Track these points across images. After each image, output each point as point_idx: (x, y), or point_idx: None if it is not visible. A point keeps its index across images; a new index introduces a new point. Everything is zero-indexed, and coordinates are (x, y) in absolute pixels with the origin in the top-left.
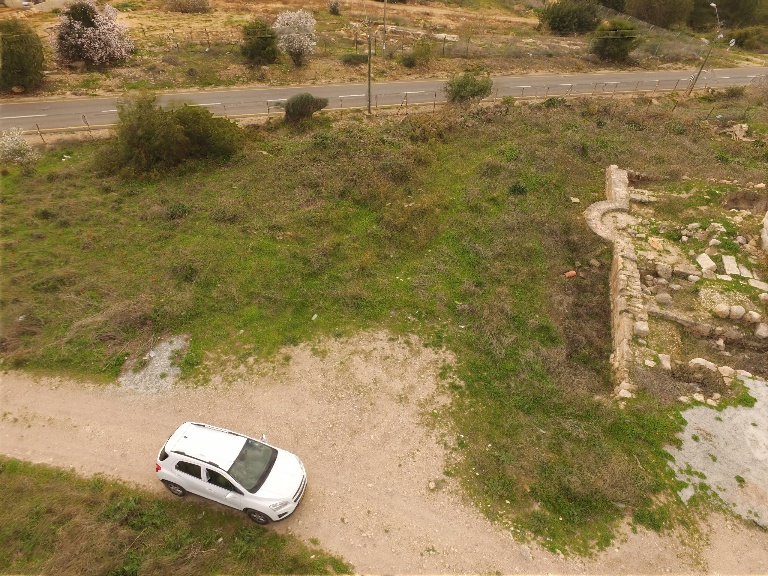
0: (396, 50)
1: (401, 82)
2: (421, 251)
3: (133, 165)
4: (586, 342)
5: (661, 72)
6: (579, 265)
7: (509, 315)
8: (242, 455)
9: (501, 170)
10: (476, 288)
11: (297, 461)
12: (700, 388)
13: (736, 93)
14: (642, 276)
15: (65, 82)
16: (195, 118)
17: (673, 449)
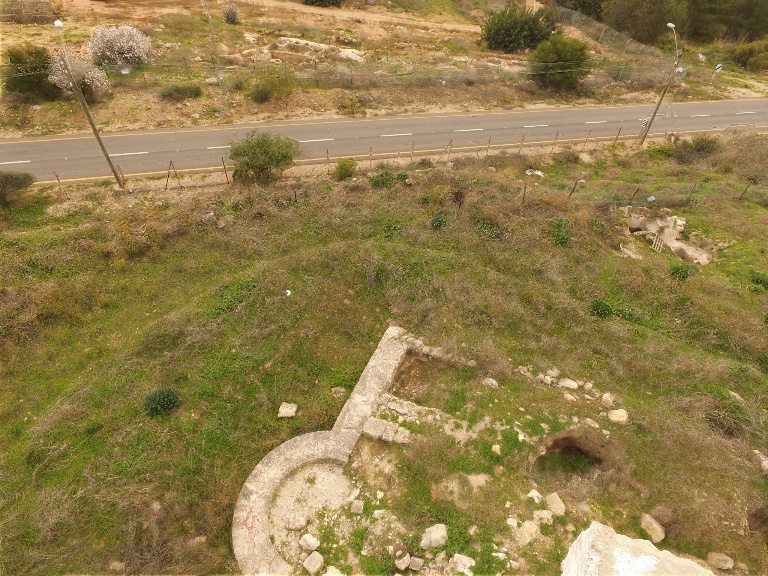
0: (248, 79)
1: (224, 128)
2: None
3: None
4: None
5: (617, 107)
6: None
7: None
8: None
9: (183, 338)
10: None
11: None
12: None
13: (704, 146)
14: None
15: None
16: None
17: None
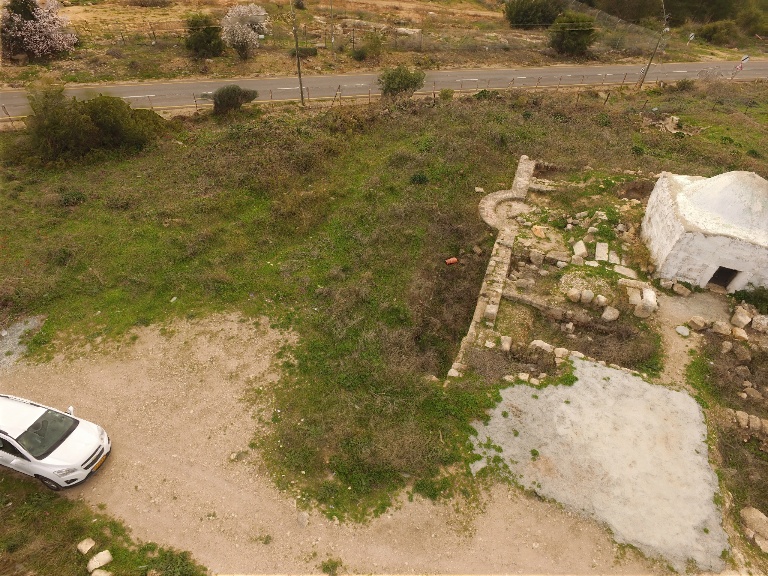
0: (347, 43)
1: (346, 75)
2: (301, 237)
3: (41, 154)
4: (441, 325)
5: (618, 66)
6: (462, 252)
7: None
8: (37, 424)
9: (410, 160)
10: (342, 273)
11: (98, 431)
12: (535, 369)
13: (685, 86)
14: (516, 262)
15: (4, 74)
16: (106, 108)
17: (480, 424)
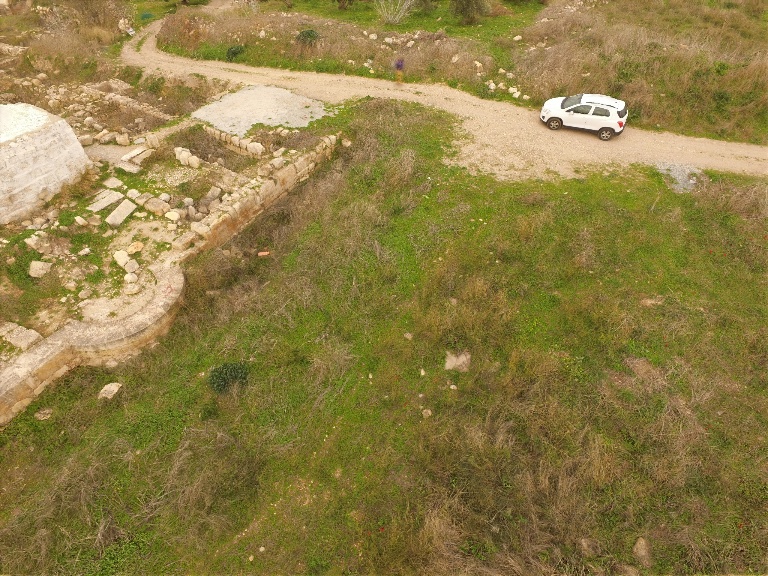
0: None
1: None
2: None
3: None
4: None
5: None
6: None
7: None
8: None
9: None
10: None
11: None
12: None
13: None
14: None
15: None
16: None
17: None
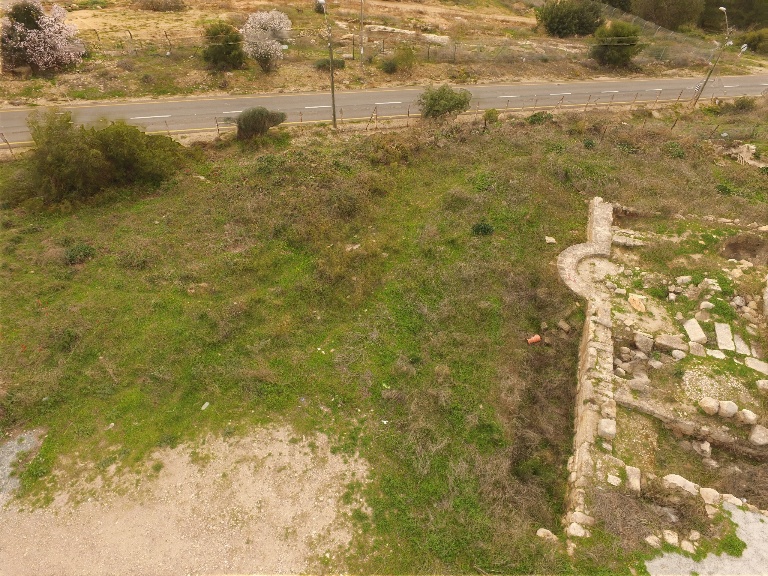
0: (376, 54)
1: (377, 91)
2: (355, 311)
3: (43, 194)
4: (540, 440)
5: (665, 79)
6: (545, 327)
7: (444, 408)
8: None
9: (468, 202)
10: (411, 365)
11: None
12: (676, 515)
13: (745, 105)
14: (617, 347)
15: (4, 90)
16: (118, 140)
17: None
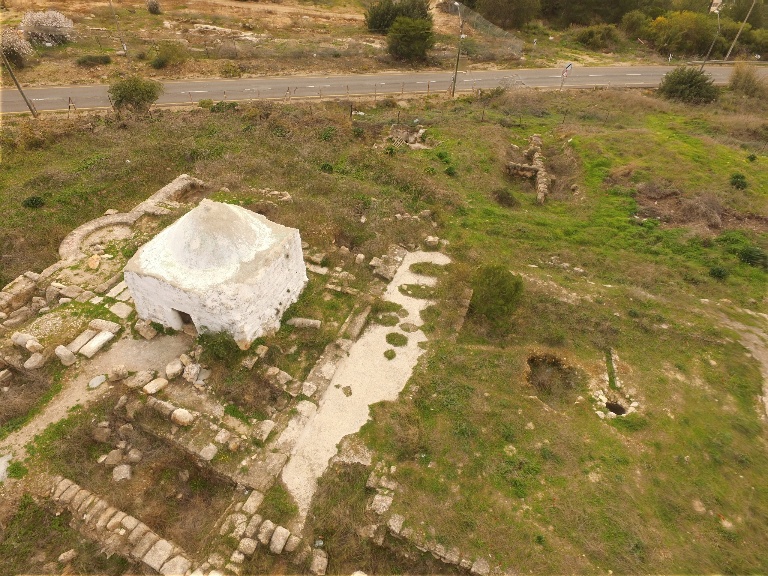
0: (150, 51)
1: None
2: None
3: None
4: None
5: (452, 72)
6: None
7: None
8: None
9: None
10: None
11: None
12: None
13: None
14: None
15: None
16: None
17: None
